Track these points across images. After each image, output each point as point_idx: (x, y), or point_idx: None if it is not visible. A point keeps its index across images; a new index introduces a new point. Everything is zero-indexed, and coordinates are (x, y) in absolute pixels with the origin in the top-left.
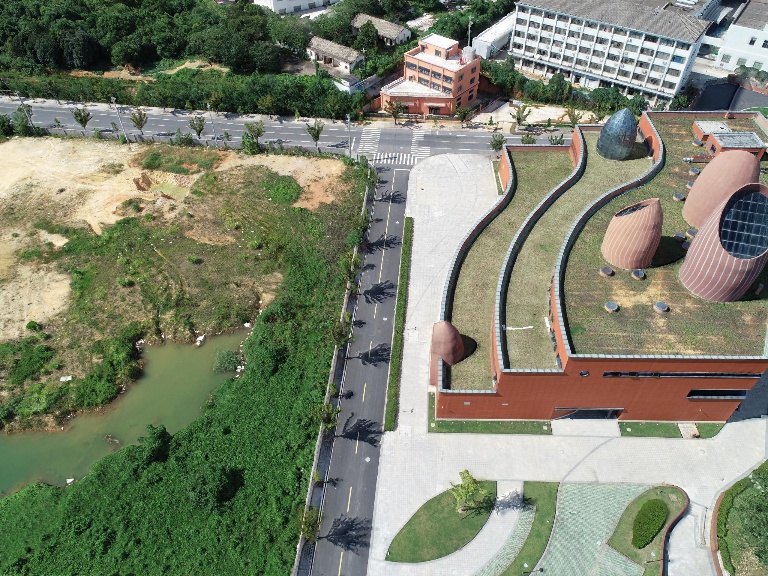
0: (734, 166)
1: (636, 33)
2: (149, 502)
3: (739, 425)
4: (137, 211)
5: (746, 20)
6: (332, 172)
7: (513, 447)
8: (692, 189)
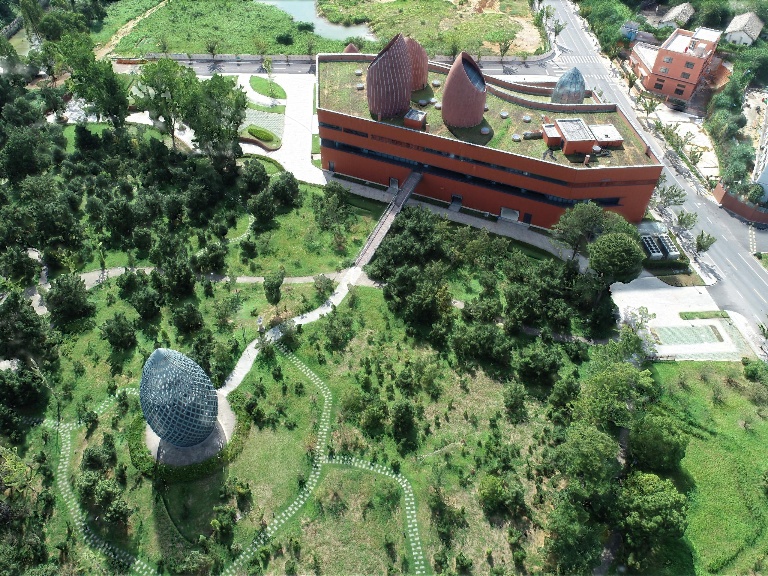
0: None
1: None
2: None
3: (321, 175)
4: (459, 4)
5: None
6: (529, 49)
7: (305, 104)
8: None
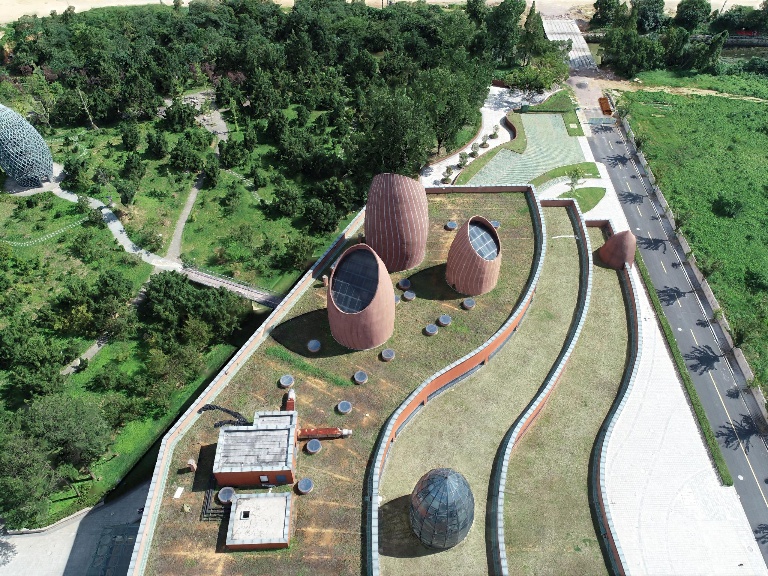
0: None
1: None
2: (761, 204)
3: None
4: None
5: None
6: None
7: None
8: None
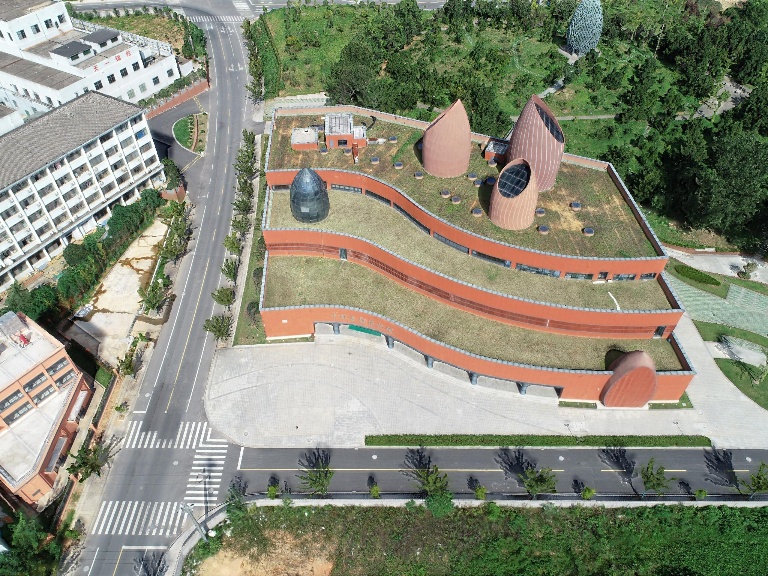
0: (463, 114)
1: (89, 144)
2: None
3: None
4: None
5: (48, 82)
6: (237, 575)
7: None
8: (444, 155)
